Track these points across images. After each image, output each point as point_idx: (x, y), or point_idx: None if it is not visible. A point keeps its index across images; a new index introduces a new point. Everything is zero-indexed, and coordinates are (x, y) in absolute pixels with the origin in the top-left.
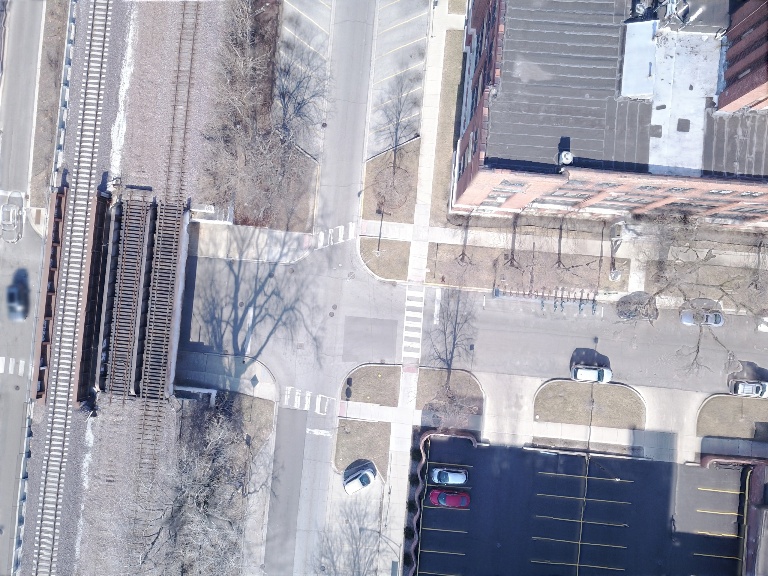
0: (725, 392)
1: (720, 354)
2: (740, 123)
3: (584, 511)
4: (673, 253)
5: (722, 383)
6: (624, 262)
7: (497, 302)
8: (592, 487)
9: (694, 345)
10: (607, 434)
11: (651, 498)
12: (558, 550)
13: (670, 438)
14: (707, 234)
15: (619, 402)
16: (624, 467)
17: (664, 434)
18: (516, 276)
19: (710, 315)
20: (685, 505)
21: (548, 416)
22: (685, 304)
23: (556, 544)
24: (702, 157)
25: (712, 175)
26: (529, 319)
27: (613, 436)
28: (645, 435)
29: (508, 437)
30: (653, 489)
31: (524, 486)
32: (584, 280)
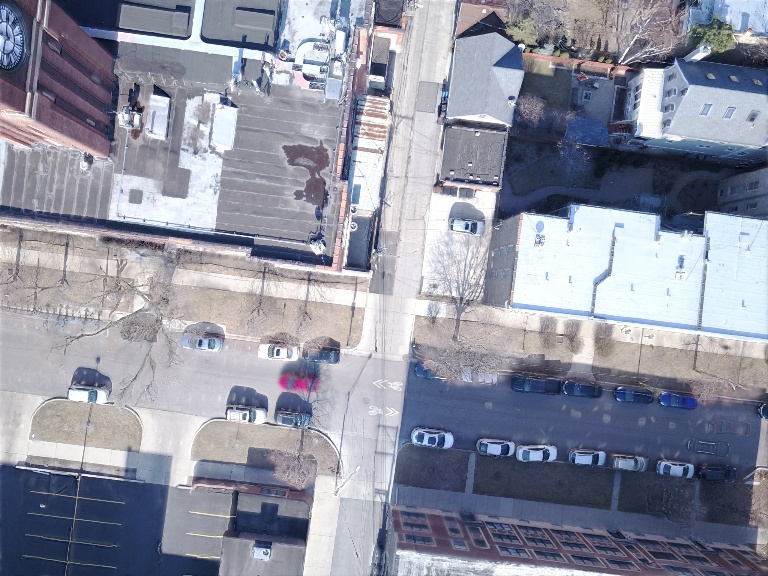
0: (224, 417)
1: (220, 379)
2: (41, 158)
3: (72, 531)
4: (178, 275)
5: (221, 408)
6: (129, 282)
7: (1, 318)
8: (83, 507)
9: (195, 369)
10: (102, 455)
11: (141, 520)
12: (44, 569)
13: (164, 461)
14: (209, 258)
15: (116, 423)
16: (116, 488)
17: (159, 457)
18: (19, 292)
19: (203, 340)
20: (174, 528)
21: (43, 435)
22: (188, 327)
23: (45, 563)
24: (1, 192)
25: (9, 211)
26: (32, 336)
27: (107, 457)
28: (139, 457)
29: (1, 455)
30: (144, 511)
31: (16, 505)
32: (88, 299)
